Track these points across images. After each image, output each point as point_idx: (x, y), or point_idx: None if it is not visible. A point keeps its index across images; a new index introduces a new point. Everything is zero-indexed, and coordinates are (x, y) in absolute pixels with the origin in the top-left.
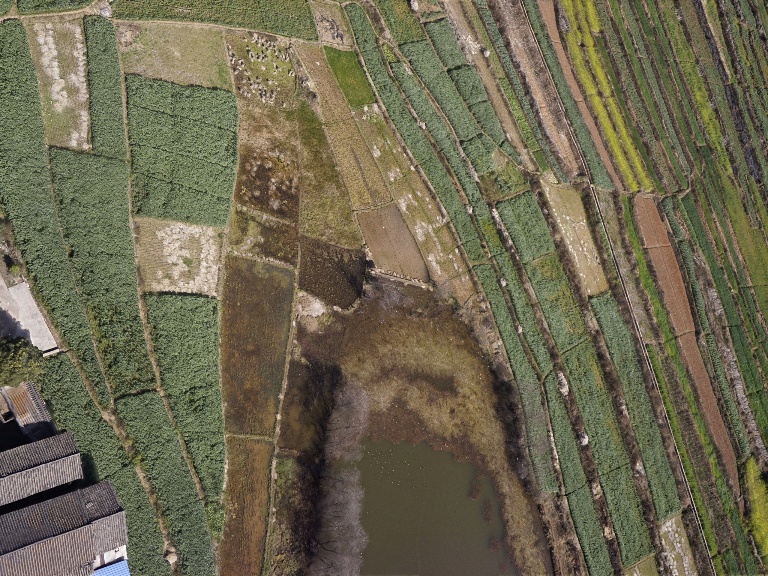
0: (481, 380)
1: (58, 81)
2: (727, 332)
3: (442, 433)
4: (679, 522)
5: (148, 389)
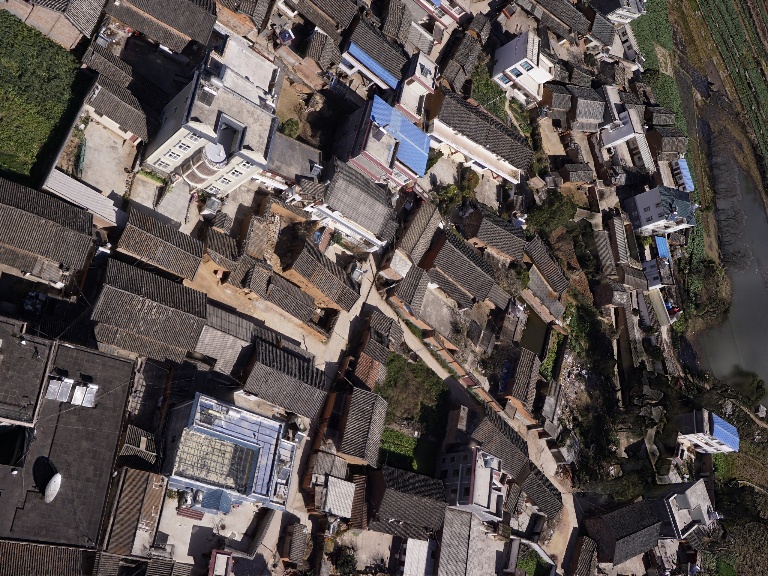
0: (750, 150)
1: None
2: None
3: (742, 166)
4: None
5: None
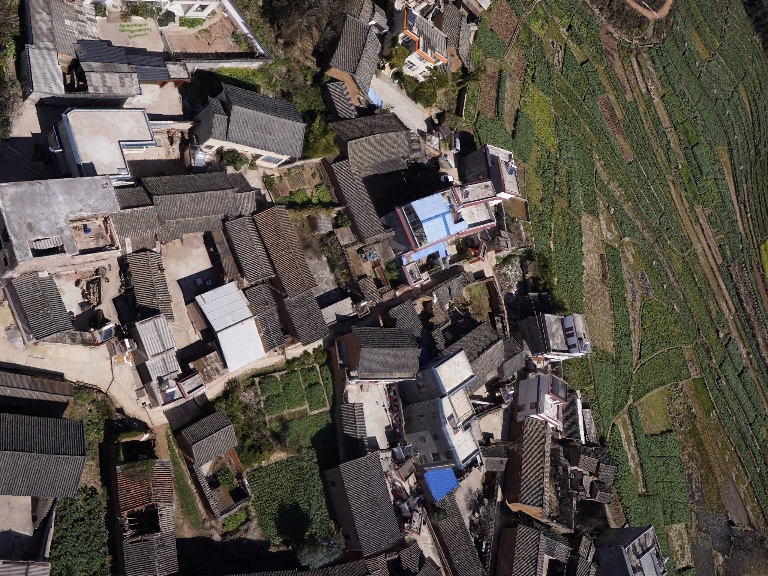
0: None
1: (629, 453)
2: None
3: None
4: None
5: None
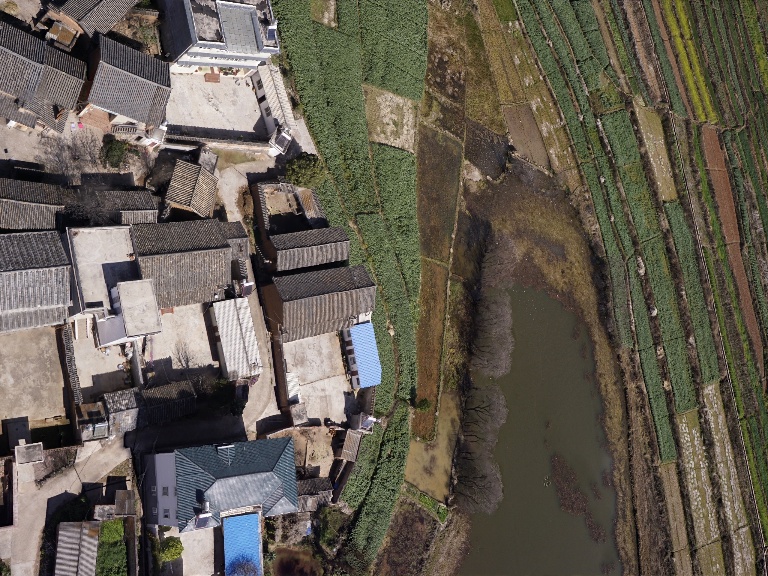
0: (583, 253)
1: None
2: (765, 247)
3: (556, 287)
4: (717, 389)
5: (374, 212)
